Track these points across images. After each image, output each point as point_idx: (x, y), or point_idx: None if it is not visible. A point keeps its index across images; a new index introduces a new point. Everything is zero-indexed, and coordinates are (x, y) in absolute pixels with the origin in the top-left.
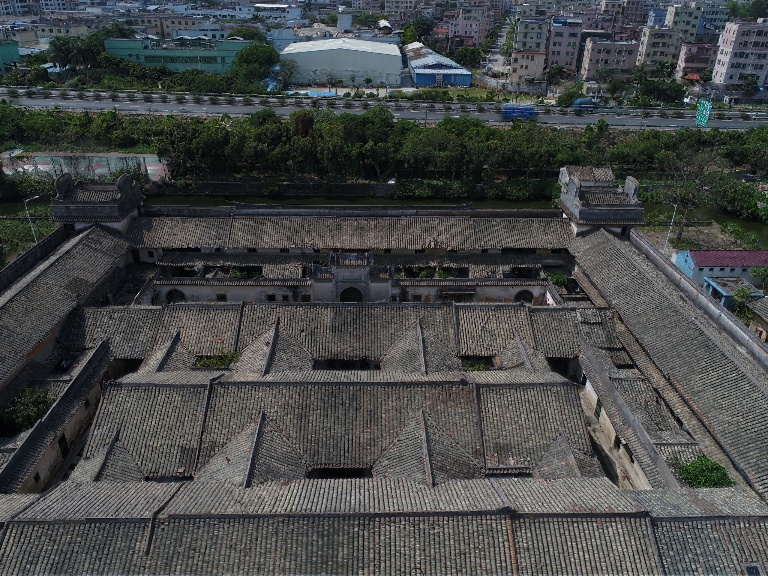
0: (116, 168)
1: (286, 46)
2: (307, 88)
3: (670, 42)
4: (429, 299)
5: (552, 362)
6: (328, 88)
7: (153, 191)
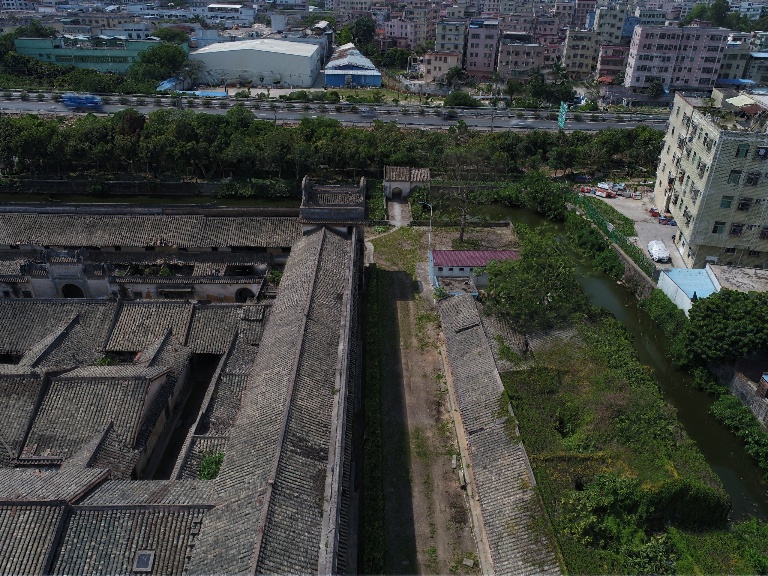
0: None
1: (205, 46)
2: (215, 88)
3: (589, 44)
4: (150, 296)
5: (207, 358)
6: (236, 88)
7: None
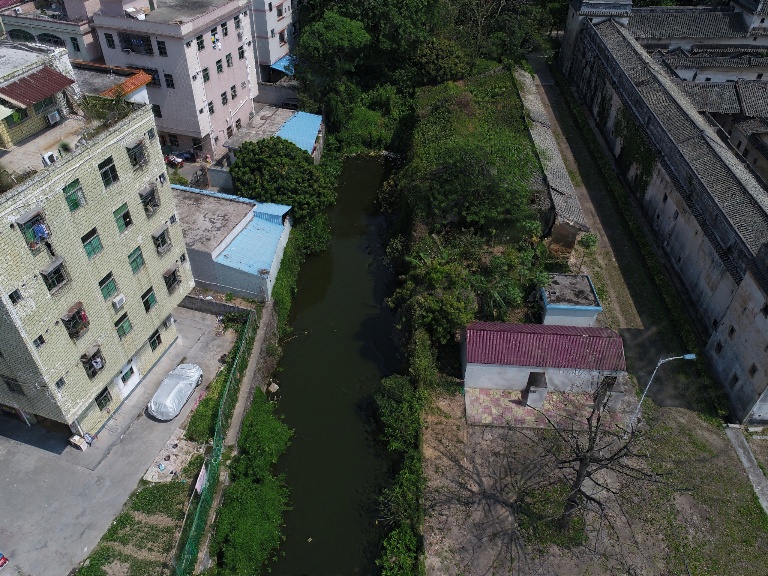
0: None
1: None
2: None
3: None
4: None
5: None
6: None
7: None
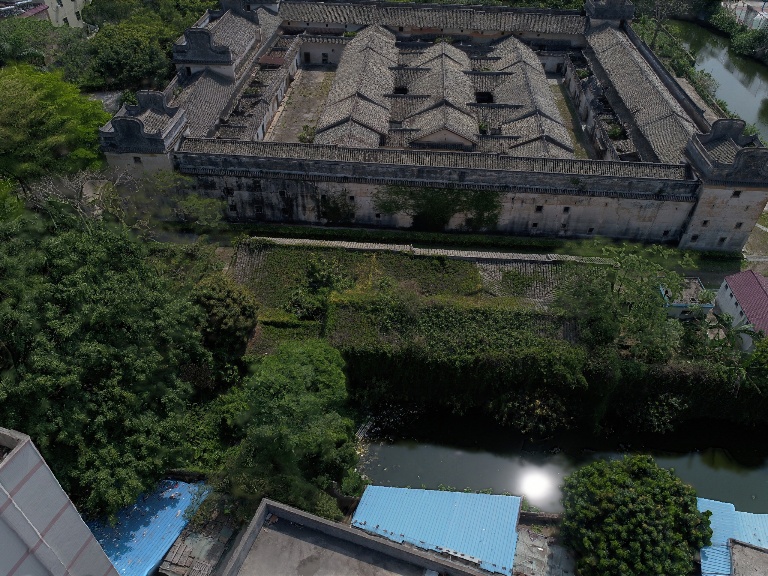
0: (761, 27)
1: None
2: None
3: None
4: None
5: None
6: None
7: (758, 55)
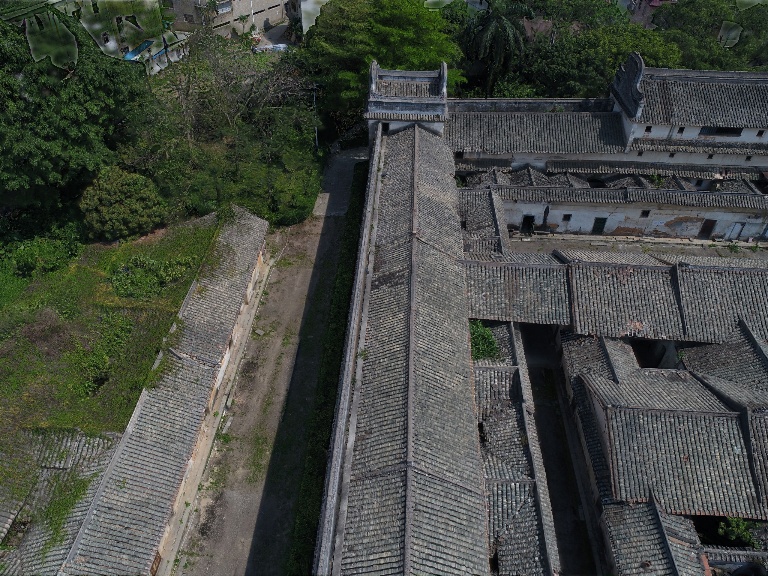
0: None
1: None
2: None
3: None
4: None
5: None
6: None
7: None
